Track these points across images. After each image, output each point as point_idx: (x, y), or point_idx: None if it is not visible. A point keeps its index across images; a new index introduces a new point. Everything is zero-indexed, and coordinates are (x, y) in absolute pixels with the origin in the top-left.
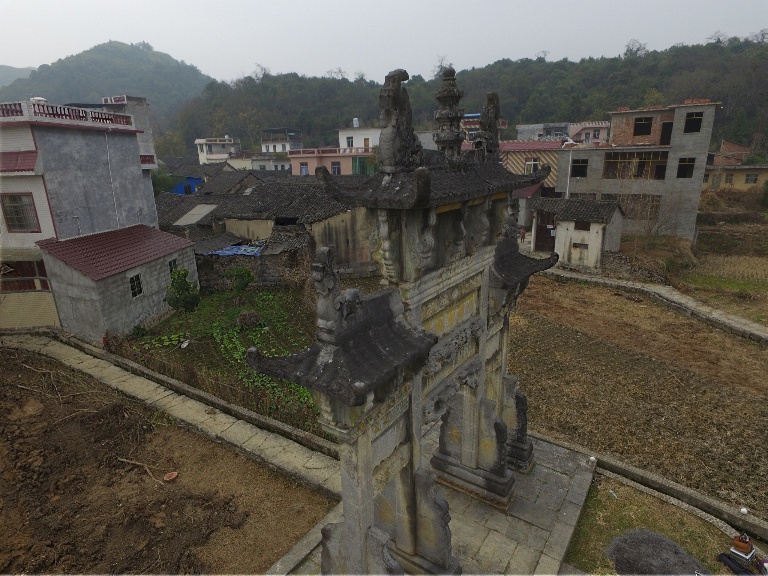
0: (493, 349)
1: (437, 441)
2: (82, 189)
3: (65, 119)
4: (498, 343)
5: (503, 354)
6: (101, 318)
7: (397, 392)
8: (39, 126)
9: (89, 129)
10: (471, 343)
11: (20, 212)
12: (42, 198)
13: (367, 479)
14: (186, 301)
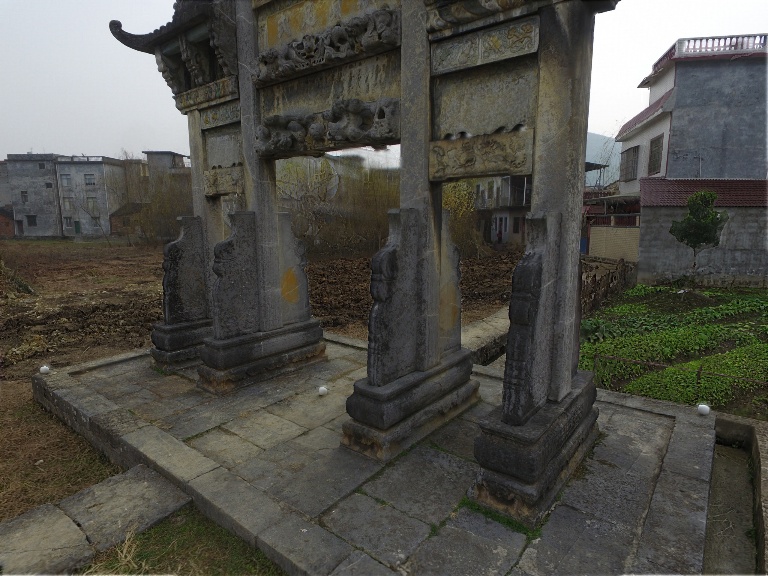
0: (500, 116)
1: None
2: (722, 128)
3: (727, 50)
4: (533, 107)
5: (538, 139)
6: (638, 248)
7: (213, 83)
8: (686, 62)
9: (761, 57)
10: (386, 71)
11: (657, 155)
12: (667, 136)
13: (196, 163)
14: (684, 228)
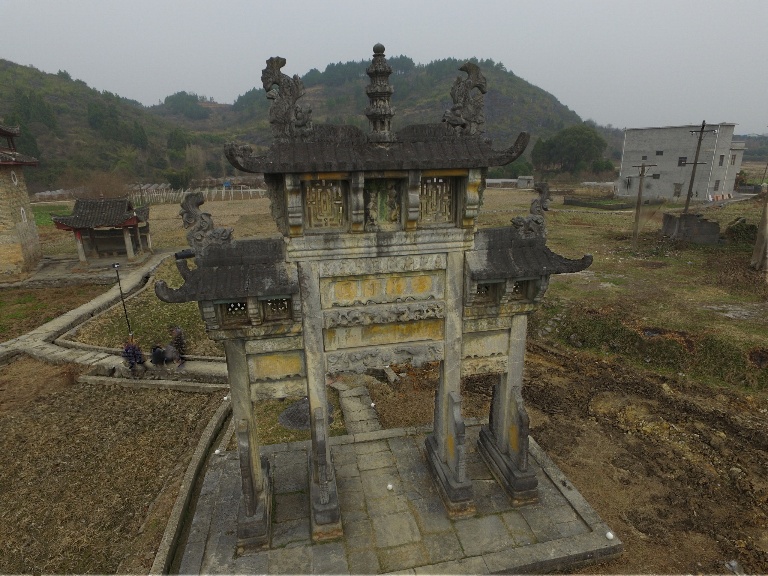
0: None
1: (266, 575)
2: None
3: None
4: None
5: None
6: None
7: None
8: None
9: None
10: None
11: None
12: None
13: None
14: None
